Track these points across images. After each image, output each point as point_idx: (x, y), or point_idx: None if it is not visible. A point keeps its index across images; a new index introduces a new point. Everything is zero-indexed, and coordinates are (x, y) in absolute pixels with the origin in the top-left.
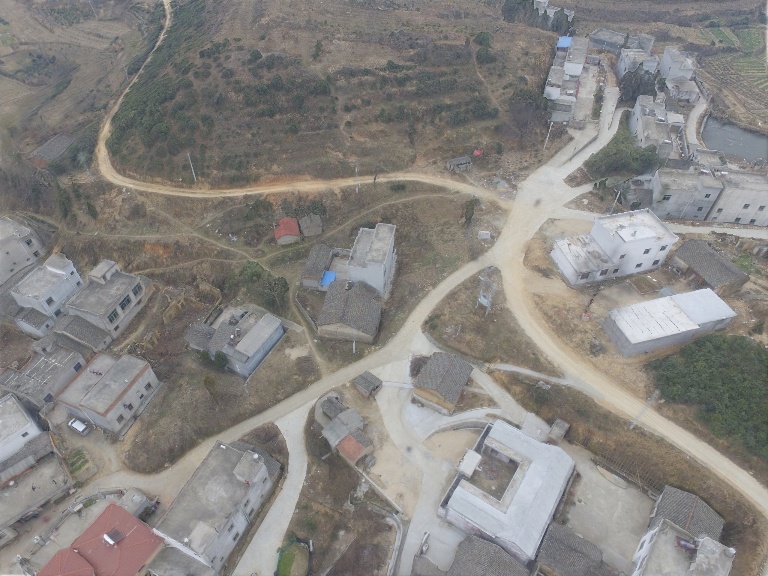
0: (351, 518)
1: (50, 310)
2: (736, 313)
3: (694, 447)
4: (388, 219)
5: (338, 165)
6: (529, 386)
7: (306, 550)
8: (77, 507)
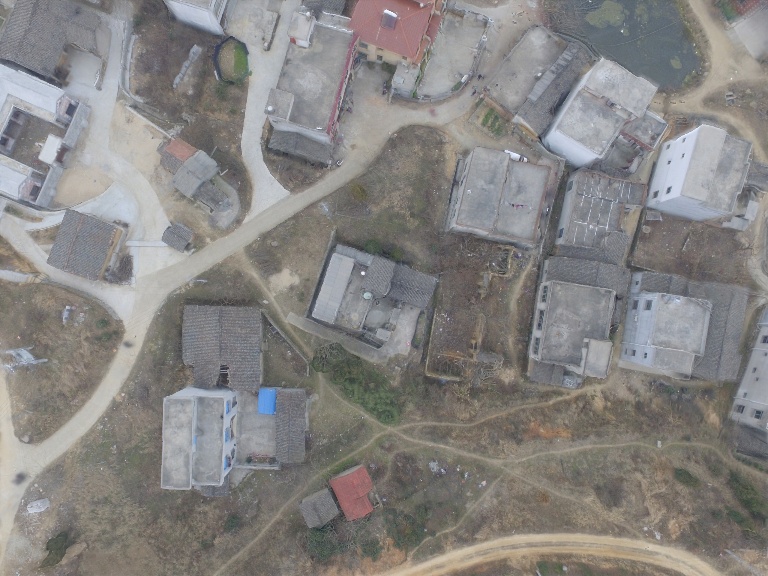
0: (184, 107)
1: (644, 298)
2: None
3: None
4: (204, 546)
5: None
6: None
7: (225, 78)
8: (466, 78)
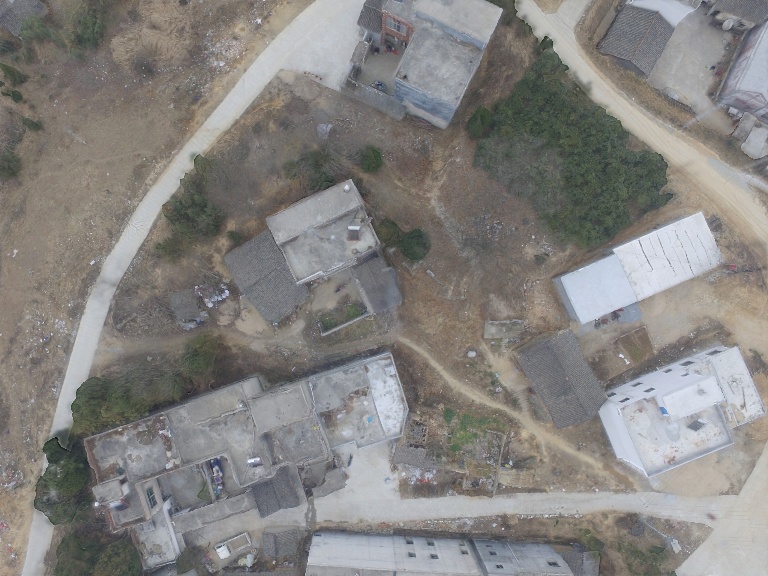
0: None
1: None
2: (545, 296)
3: (626, 111)
4: None
5: None
6: None
7: None
8: None
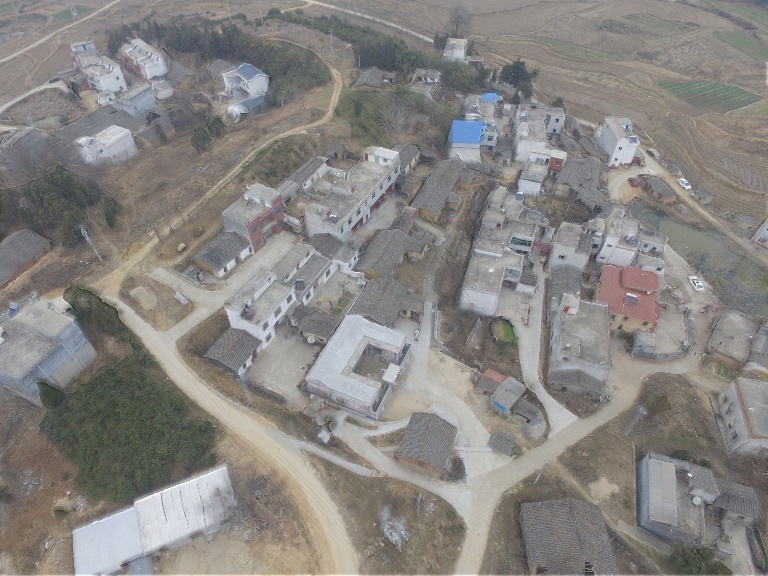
0: (474, 356)
1: None
2: (62, 555)
3: (203, 394)
4: None
5: None
6: (337, 445)
7: None
8: (687, 342)
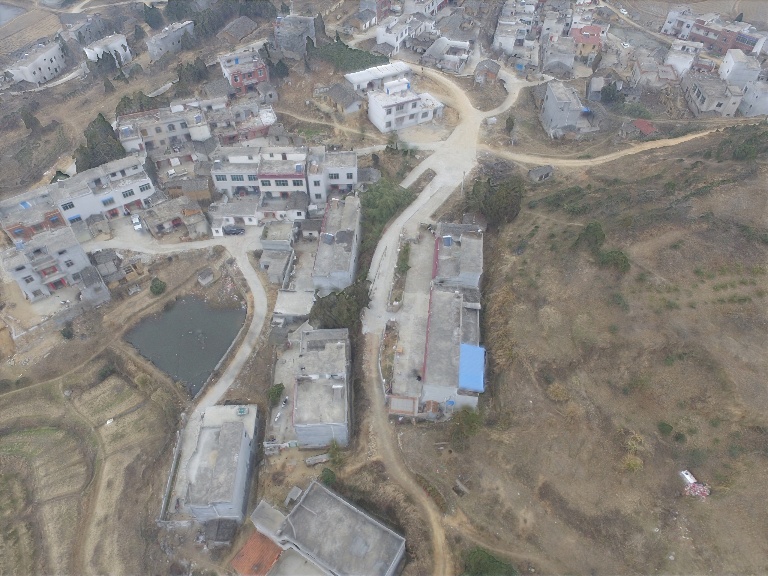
0: None
1: None
2: None
3: None
4: None
5: (652, 150)
6: None
7: None
8: None
